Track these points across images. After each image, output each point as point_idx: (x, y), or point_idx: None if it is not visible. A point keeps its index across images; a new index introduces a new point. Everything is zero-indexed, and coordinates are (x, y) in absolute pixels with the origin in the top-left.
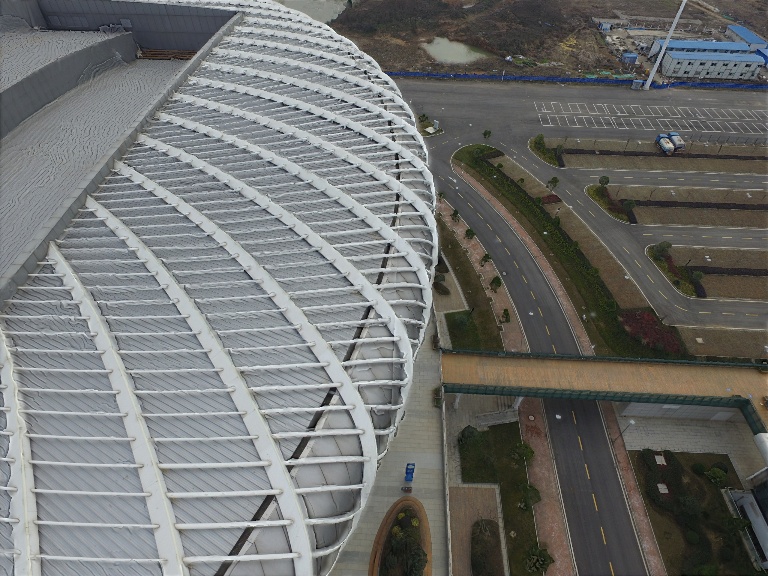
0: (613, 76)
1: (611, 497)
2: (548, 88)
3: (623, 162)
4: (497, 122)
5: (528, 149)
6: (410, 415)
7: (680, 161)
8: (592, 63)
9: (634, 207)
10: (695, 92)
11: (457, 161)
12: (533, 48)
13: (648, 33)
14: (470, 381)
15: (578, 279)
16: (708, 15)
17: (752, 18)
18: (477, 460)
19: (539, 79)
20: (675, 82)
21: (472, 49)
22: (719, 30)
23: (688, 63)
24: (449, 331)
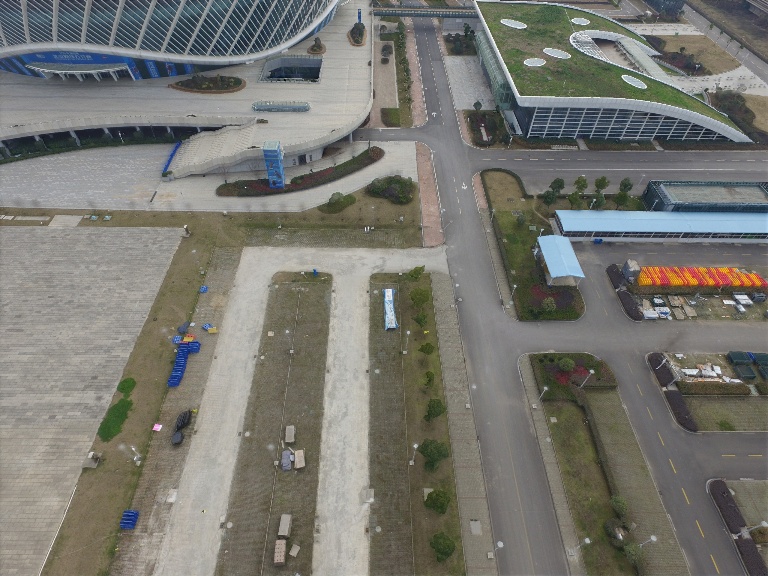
0: None
1: None
2: None
3: None
4: None
5: None
6: None
7: None
8: None
9: None
10: None
11: None
12: None
13: None
14: None
15: (436, 3)
16: None
17: None
18: None
19: None
20: None
21: None
22: None
23: None
24: None
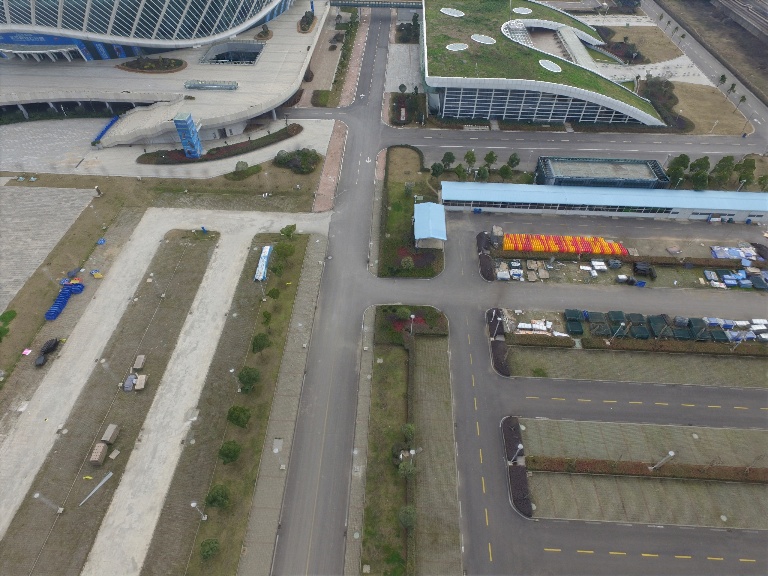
0: None
1: (385, 31)
2: None
3: None
4: None
5: None
6: (316, 6)
7: None
8: None
9: None
10: None
11: None
12: None
13: None
14: (340, 2)
15: None
16: None
17: None
18: (341, 26)
19: None
20: None
21: None
22: None
23: None
24: (340, 8)
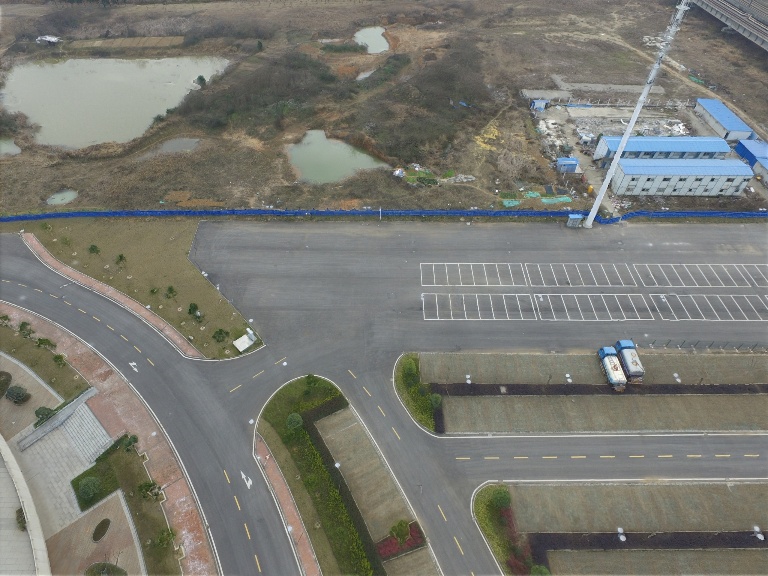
0: (542, 201)
1: None
2: (446, 231)
3: (543, 413)
4: (354, 316)
5: (391, 385)
6: None
7: (637, 404)
8: (515, 174)
9: (554, 557)
10: (658, 229)
11: (265, 426)
12: (437, 148)
13: (594, 113)
14: None
15: None
16: (672, 77)
17: (727, 80)
18: None
19: (435, 213)
20: (629, 212)
21: (356, 149)
22: (687, 104)
23: (646, 179)
24: None
